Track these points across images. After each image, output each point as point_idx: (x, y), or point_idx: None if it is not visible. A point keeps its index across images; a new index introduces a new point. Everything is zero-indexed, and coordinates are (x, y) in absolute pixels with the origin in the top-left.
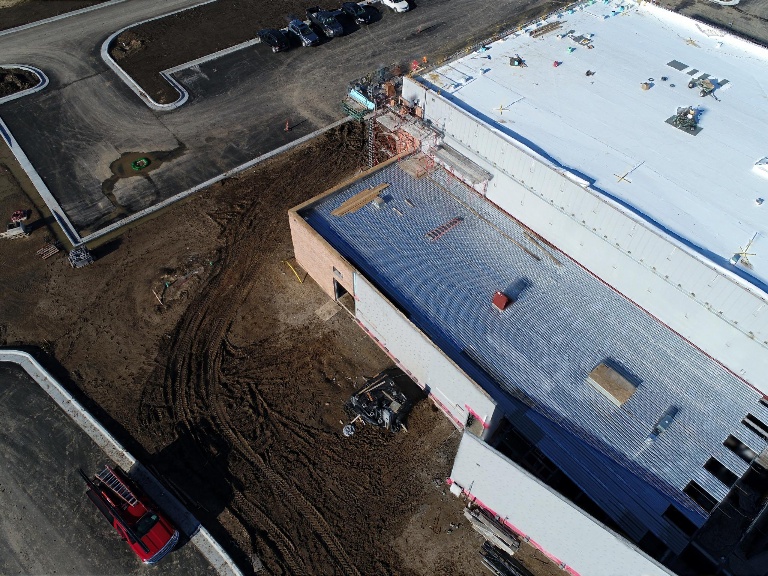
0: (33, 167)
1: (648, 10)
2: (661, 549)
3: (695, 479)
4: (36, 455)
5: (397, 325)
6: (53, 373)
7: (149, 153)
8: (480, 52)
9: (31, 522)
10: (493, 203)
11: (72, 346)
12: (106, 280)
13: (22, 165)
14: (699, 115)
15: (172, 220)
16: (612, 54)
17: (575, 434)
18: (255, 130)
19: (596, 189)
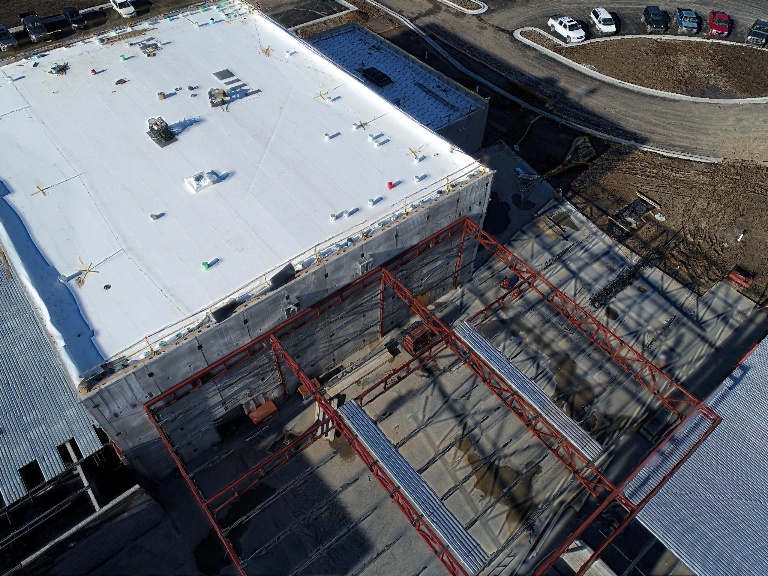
0: None
1: (255, 18)
2: None
3: None
4: None
5: None
6: None
7: None
8: (31, 59)
9: None
10: None
11: None
12: None
13: None
14: (189, 126)
15: None
16: (166, 62)
17: None
18: None
19: (1, 202)
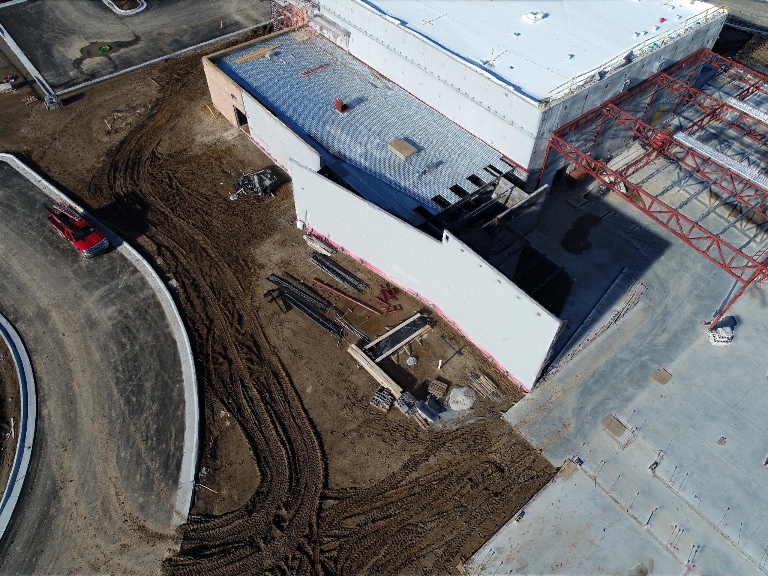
0: (20, 50)
1: None
2: None
3: (441, 194)
4: (16, 208)
5: (269, 124)
6: (29, 166)
7: (112, 42)
8: None
9: (11, 240)
10: (354, 56)
11: (44, 153)
12: (72, 117)
13: (12, 48)
14: None
15: (124, 82)
16: None
17: (371, 173)
18: (197, 28)
19: None
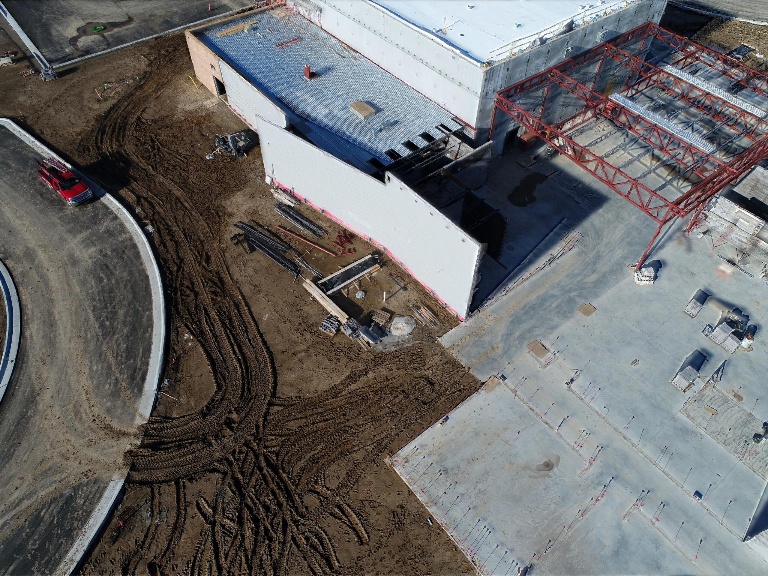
0: (21, 29)
1: None
2: None
3: (394, 148)
4: (10, 164)
5: (242, 89)
6: (24, 129)
7: (106, 23)
8: None
9: (4, 191)
10: (326, 31)
11: (38, 118)
12: (65, 87)
13: (14, 28)
14: None
15: (116, 58)
16: None
17: (331, 131)
18: (186, 11)
19: None
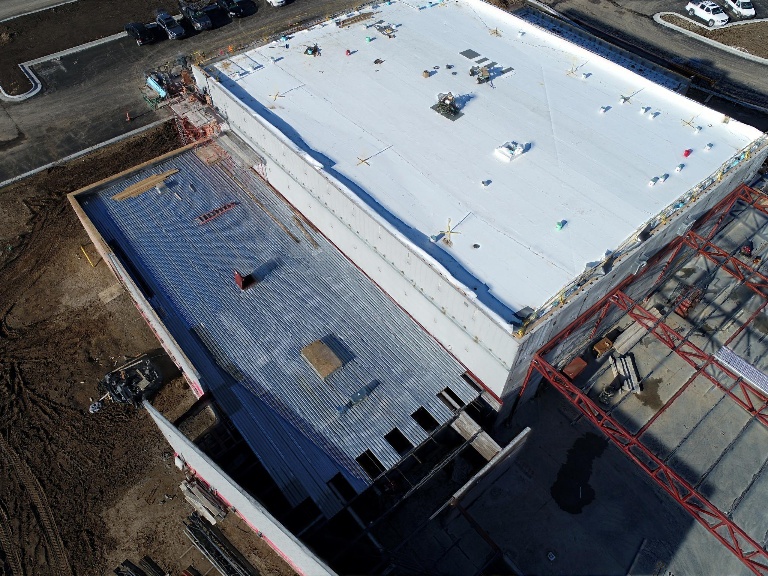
0: None
1: (467, 1)
2: (314, 514)
3: (371, 448)
4: None
5: None
6: None
7: None
8: (280, 41)
9: None
10: (274, 188)
11: None
12: None
13: None
14: (467, 101)
15: None
16: (410, 43)
17: (271, 406)
18: (98, 120)
19: (332, 171)
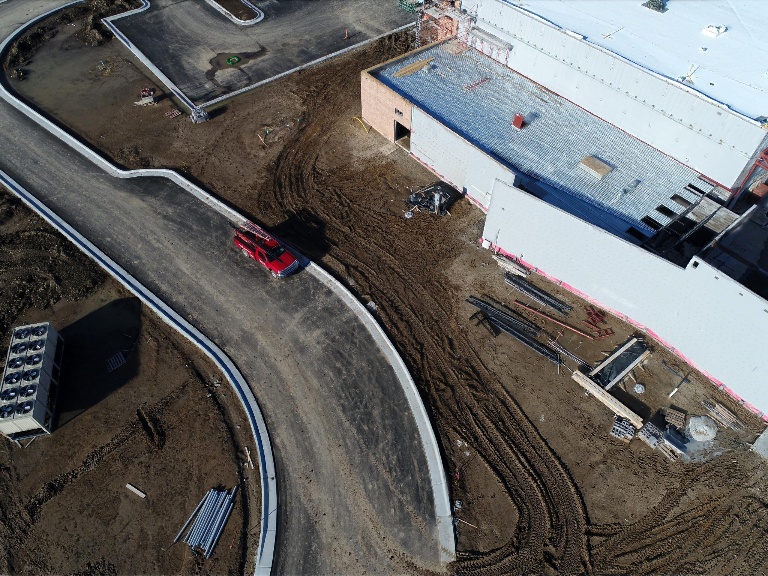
0: (150, 61)
1: None
2: None
3: (649, 215)
4: (190, 226)
5: (444, 140)
6: (193, 182)
7: (238, 53)
8: None
9: (195, 259)
10: (513, 70)
11: (203, 168)
12: (220, 131)
13: (141, 60)
14: (667, 1)
15: (264, 95)
16: None
17: (569, 193)
18: (320, 39)
19: None
